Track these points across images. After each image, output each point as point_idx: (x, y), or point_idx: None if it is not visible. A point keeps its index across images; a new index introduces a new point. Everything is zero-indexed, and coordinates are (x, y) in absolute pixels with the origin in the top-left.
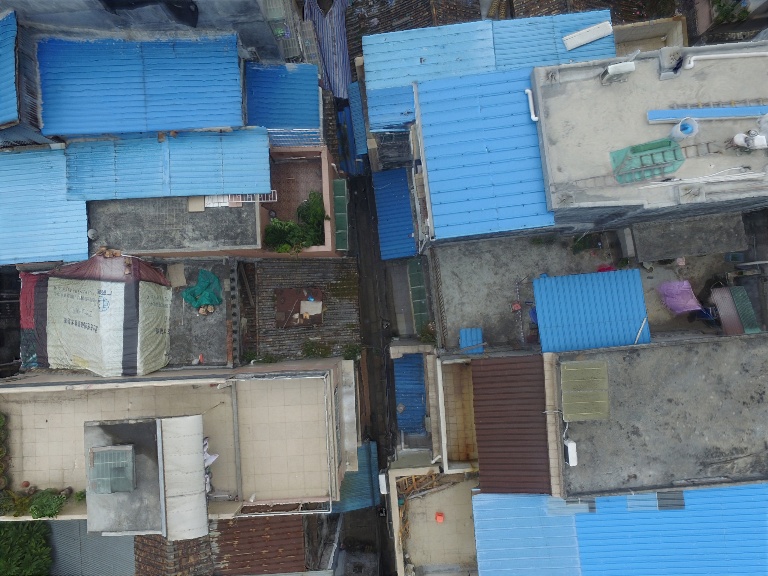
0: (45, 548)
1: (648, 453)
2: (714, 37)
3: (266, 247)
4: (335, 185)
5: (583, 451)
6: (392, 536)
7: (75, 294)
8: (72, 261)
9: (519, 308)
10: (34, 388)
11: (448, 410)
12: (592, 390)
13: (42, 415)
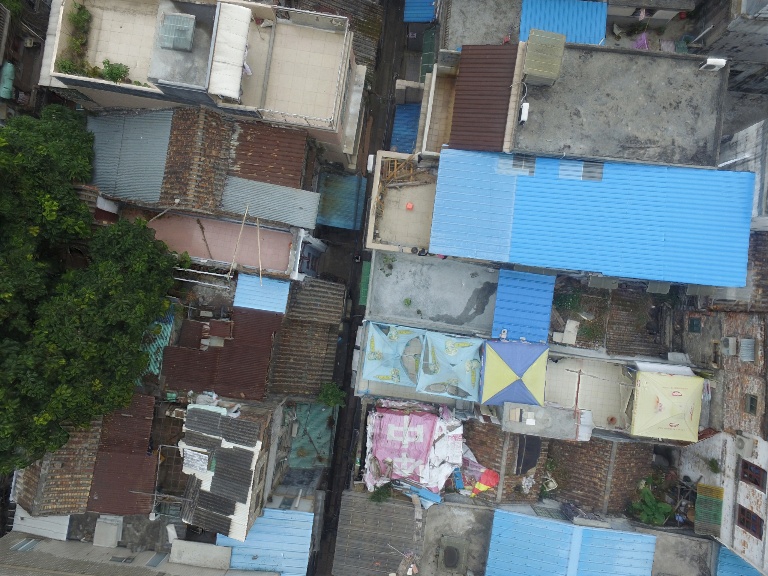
0: (88, 164)
1: (583, 131)
2: None
3: None
4: None
5: (534, 120)
6: (365, 248)
7: None
8: None
9: (508, 40)
10: None
11: (434, 118)
12: (550, 54)
13: (118, 22)
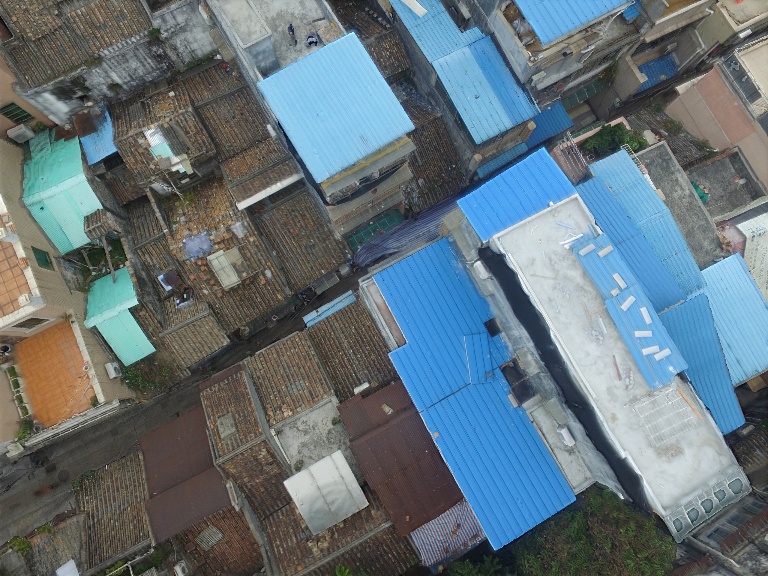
0: None
1: None
2: None
3: None
4: None
5: None
6: None
7: None
8: None
9: None
10: None
11: None
12: None
13: None
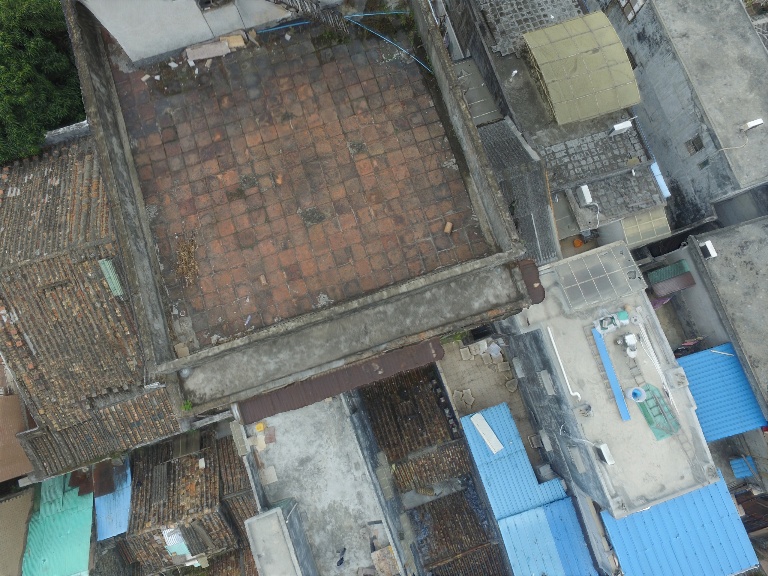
0: None
1: None
2: (470, 336)
3: None
4: None
5: None
6: None
7: None
8: None
9: None
10: None
11: None
12: None
13: None
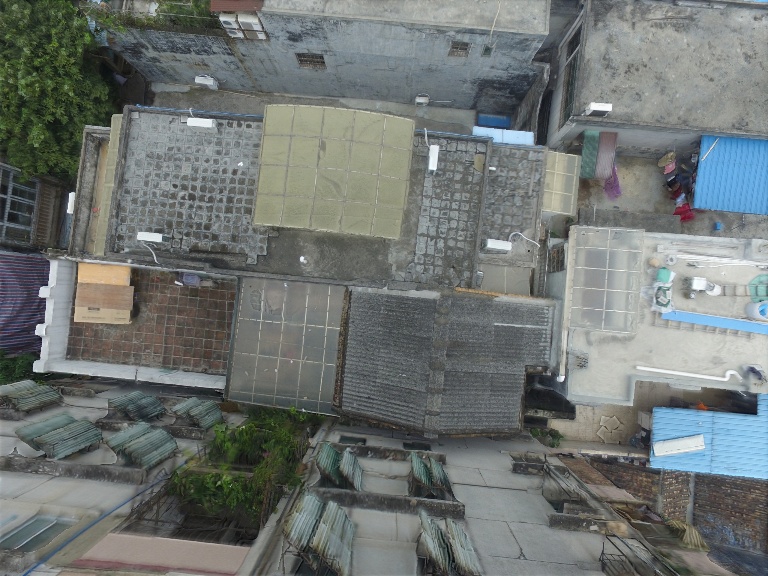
0: None
1: (740, 37)
2: (568, 416)
3: None
4: None
5: None
6: None
7: None
8: None
9: None
10: None
11: None
12: None
13: None
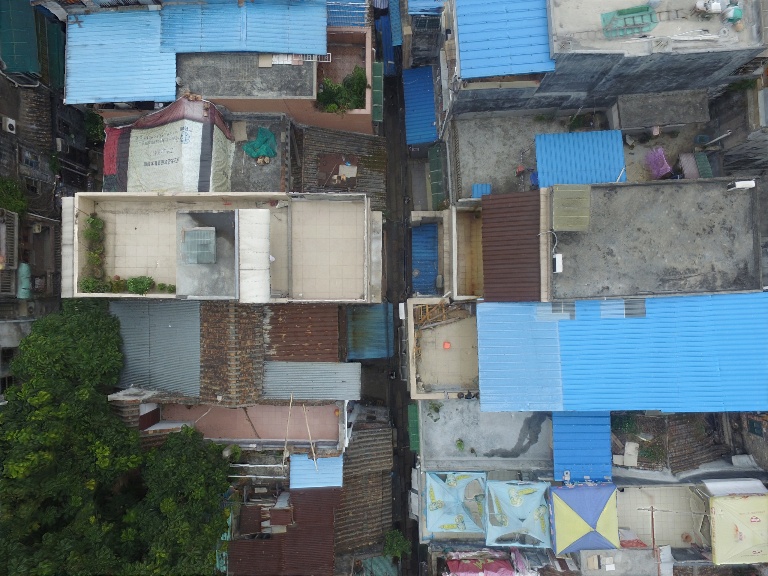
0: (118, 353)
1: (619, 270)
2: None
3: (319, 103)
4: (374, 67)
5: (568, 266)
6: (403, 378)
7: (156, 139)
8: (162, 102)
9: (522, 170)
10: (132, 193)
11: (459, 255)
12: (577, 207)
13: (132, 224)
